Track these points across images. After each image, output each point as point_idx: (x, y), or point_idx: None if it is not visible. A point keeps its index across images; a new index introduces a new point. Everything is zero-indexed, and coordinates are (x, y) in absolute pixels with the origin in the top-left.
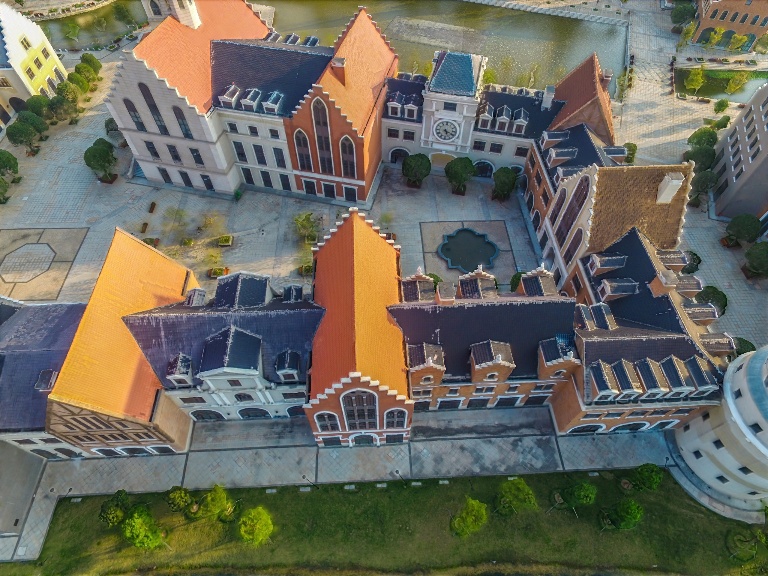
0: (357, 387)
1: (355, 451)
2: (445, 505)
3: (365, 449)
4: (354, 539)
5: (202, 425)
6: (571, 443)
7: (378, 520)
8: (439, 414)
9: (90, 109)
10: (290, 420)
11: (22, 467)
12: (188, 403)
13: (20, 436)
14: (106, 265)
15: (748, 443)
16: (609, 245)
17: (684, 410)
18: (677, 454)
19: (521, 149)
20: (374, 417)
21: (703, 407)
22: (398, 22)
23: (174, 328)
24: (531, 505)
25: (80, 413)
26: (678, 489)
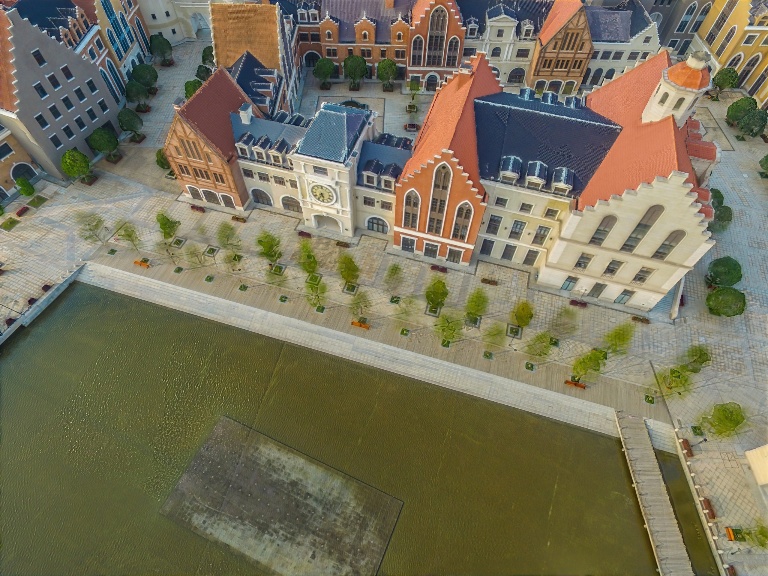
0: None
1: None
2: None
3: None
4: None
5: None
6: None
7: None
8: None
9: None
10: None
11: None
12: None
13: None
14: None
15: None
16: None
17: None
18: None
19: None
20: None
21: None
22: (359, 573)
23: None
24: None
25: None
26: None
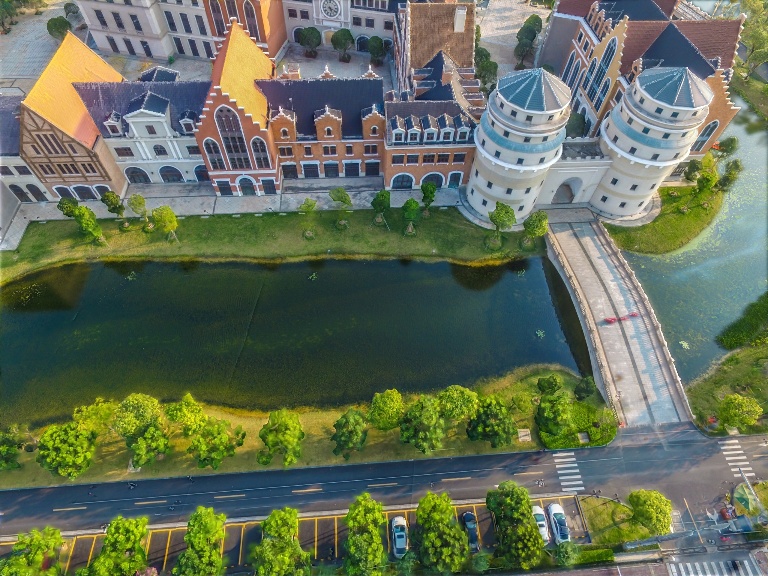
0: (222, 103)
1: (242, 198)
2: (301, 224)
3: (250, 197)
4: (236, 241)
5: (134, 186)
6: (394, 194)
7: (254, 232)
8: (305, 180)
9: (53, 5)
10: (198, 183)
11: (3, 195)
12: (121, 156)
13: (2, 161)
14: (60, 49)
15: (484, 159)
16: (425, 64)
17: (459, 157)
18: (465, 199)
19: (388, 23)
20: (245, 150)
21: (469, 152)
22: None
23: (108, 92)
24: (347, 203)
25: (43, 128)
26: (460, 216)
